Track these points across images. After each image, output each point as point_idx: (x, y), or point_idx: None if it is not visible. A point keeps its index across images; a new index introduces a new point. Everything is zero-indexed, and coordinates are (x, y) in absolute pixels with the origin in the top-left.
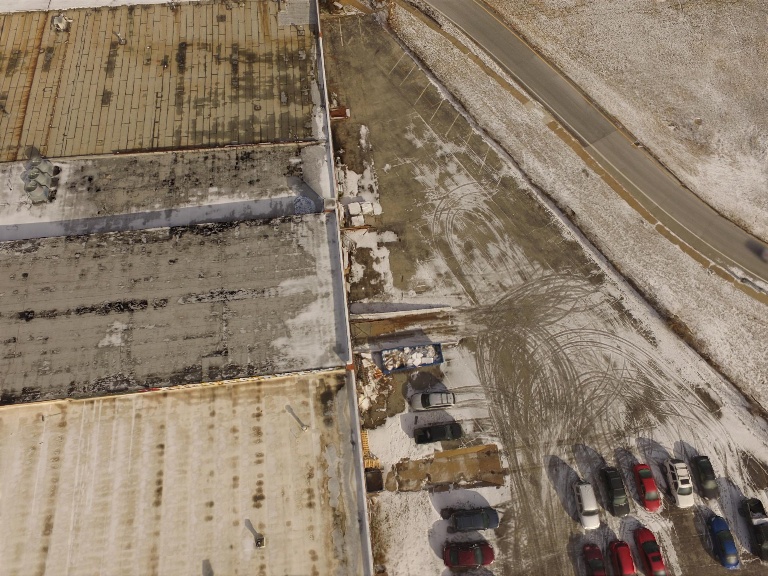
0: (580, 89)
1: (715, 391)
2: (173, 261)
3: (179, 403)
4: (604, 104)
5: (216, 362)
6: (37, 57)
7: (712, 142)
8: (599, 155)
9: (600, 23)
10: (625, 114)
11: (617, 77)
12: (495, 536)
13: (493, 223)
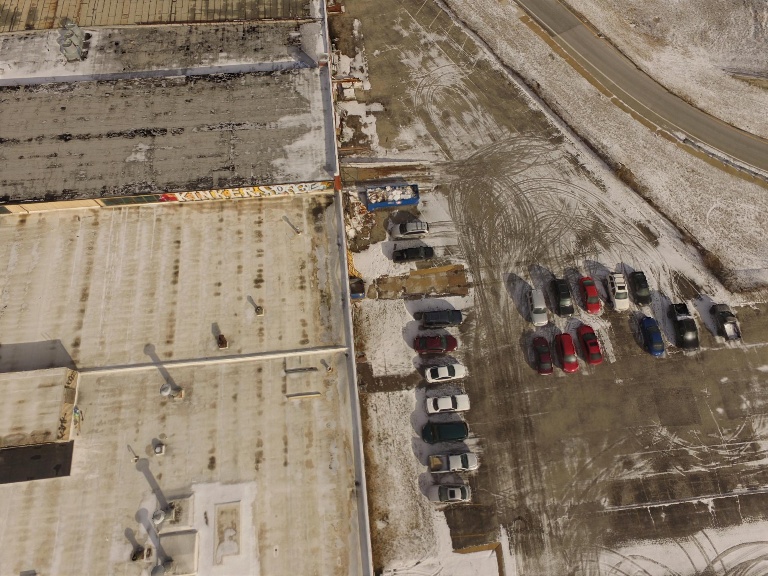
0: None
1: (654, 226)
2: (189, 101)
3: (193, 212)
4: (572, 3)
5: (224, 175)
6: None
7: (667, 36)
8: (565, 43)
9: None
10: (590, 11)
11: None
12: (459, 332)
13: (468, 96)
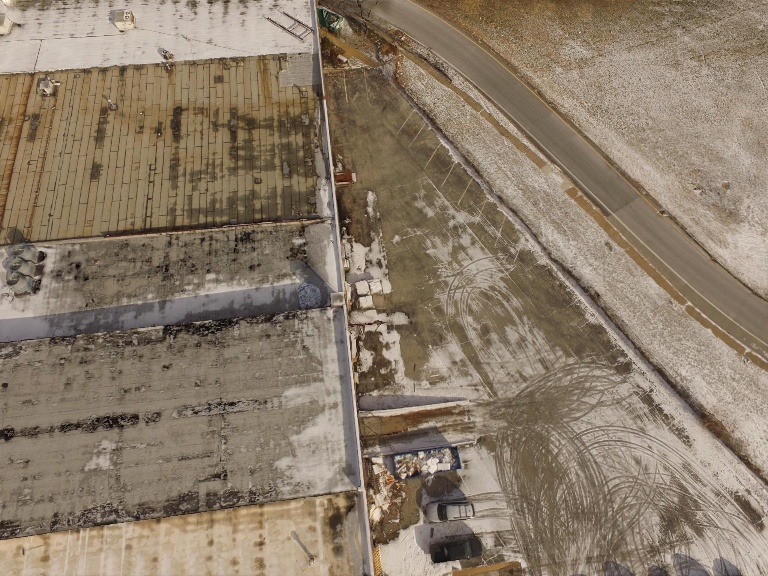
0: (600, 150)
1: (756, 499)
2: (167, 367)
3: (174, 530)
4: (626, 167)
5: (214, 487)
6: (22, 125)
7: (741, 209)
8: (622, 225)
9: (619, 76)
10: (648, 178)
11: (638, 135)
12: None
13: (511, 303)
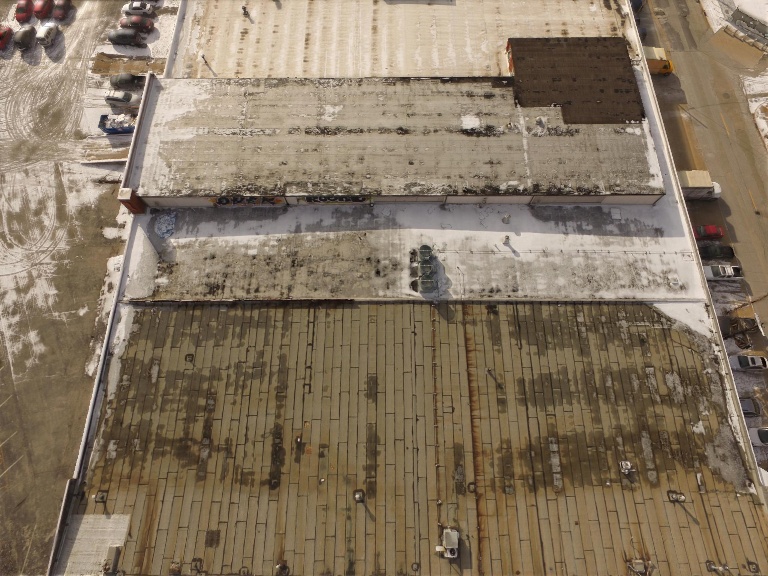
0: None
1: None
2: (283, 164)
3: None
4: None
5: (254, 89)
6: (476, 475)
7: None
8: None
9: None
10: None
11: None
12: None
13: (1, 230)
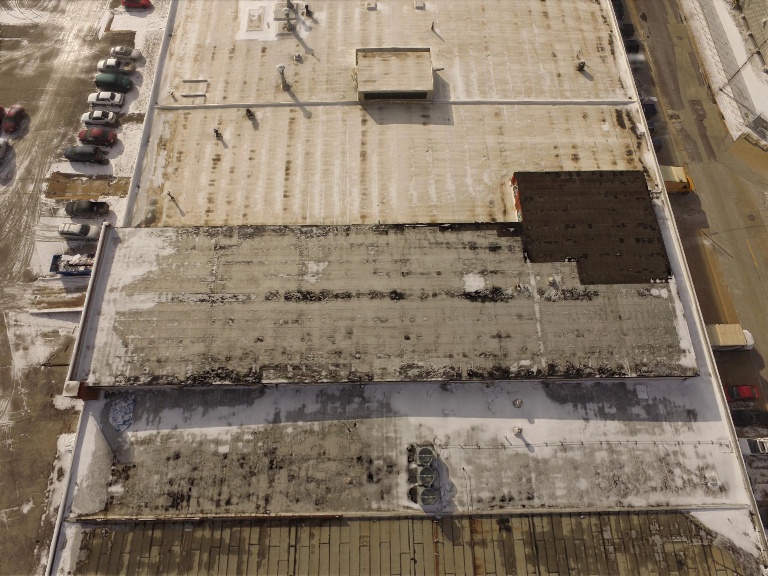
0: None
1: None
2: (259, 340)
3: None
4: None
5: (226, 240)
6: None
7: None
8: None
9: None
10: None
11: None
12: None
13: None
